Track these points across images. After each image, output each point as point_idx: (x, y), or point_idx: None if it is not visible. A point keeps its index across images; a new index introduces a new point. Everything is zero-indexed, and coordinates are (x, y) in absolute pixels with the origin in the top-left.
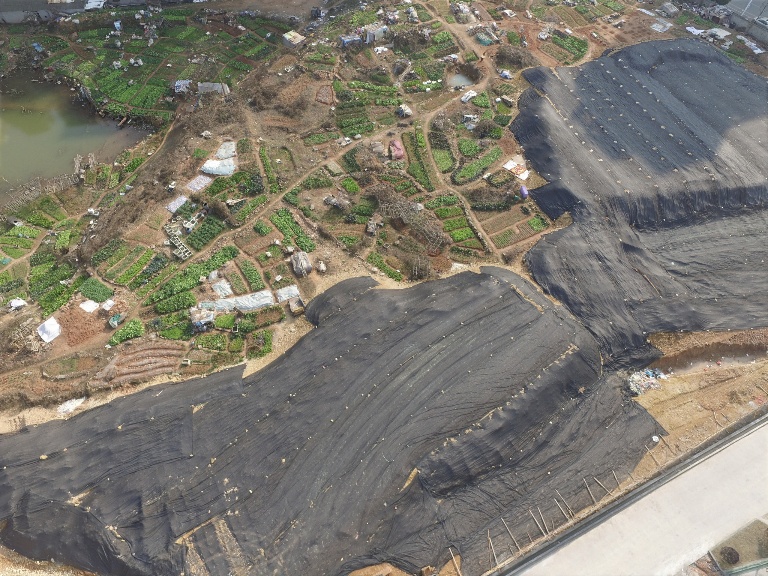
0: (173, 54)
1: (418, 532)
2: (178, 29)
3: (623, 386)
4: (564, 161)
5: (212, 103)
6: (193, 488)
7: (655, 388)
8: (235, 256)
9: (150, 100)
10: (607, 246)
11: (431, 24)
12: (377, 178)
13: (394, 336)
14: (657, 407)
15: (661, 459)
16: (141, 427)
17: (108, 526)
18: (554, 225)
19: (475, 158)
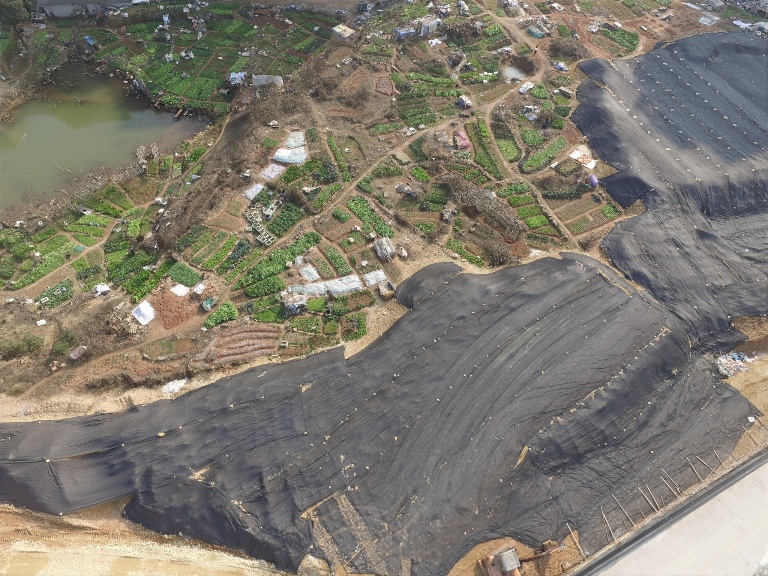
0: (223, 47)
1: (535, 507)
2: (225, 23)
3: (712, 369)
4: (632, 150)
5: (270, 95)
6: (311, 464)
7: (744, 370)
8: (318, 242)
9: (205, 92)
10: (683, 233)
11: (482, 17)
12: (445, 167)
13: (489, 319)
14: (749, 389)
15: (759, 439)
16: (253, 406)
17: (233, 501)
18: (626, 213)
19: (540, 148)
